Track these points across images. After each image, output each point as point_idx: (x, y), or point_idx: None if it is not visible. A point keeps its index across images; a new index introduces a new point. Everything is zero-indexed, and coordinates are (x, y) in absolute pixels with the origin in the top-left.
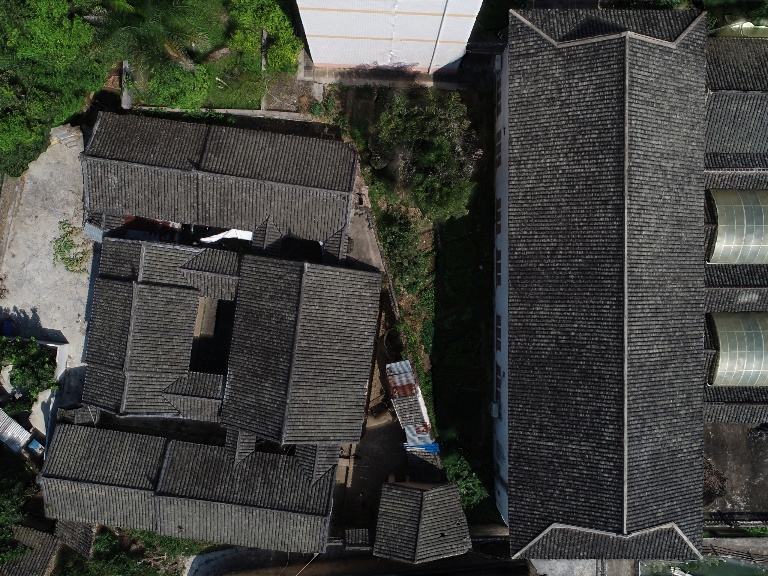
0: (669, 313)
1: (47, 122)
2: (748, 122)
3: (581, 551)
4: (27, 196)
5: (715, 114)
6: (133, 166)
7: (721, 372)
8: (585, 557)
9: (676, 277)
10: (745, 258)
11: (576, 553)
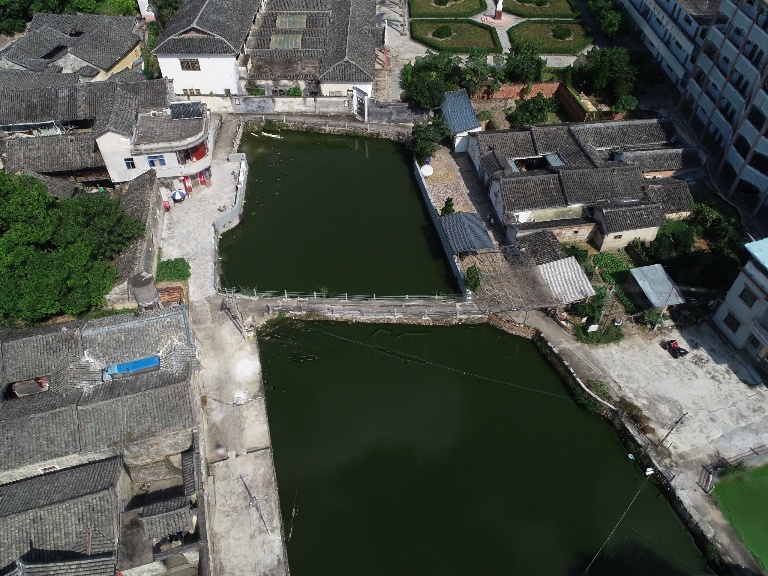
0: (235, 3)
1: (27, 0)
2: (295, 2)
3: (182, 49)
4: (5, 46)
5: (281, 0)
6: (54, 16)
7: (272, 41)
8: (184, 52)
9: (242, 0)
10: (290, 26)
11: (180, 50)
